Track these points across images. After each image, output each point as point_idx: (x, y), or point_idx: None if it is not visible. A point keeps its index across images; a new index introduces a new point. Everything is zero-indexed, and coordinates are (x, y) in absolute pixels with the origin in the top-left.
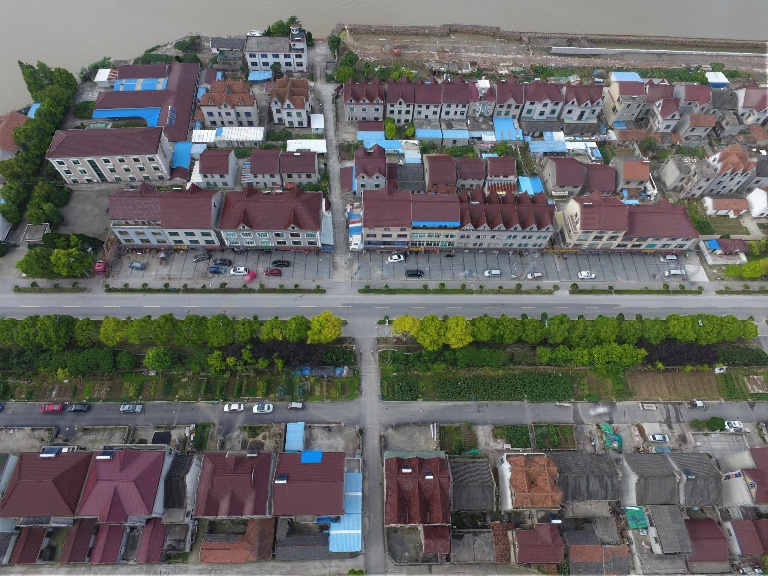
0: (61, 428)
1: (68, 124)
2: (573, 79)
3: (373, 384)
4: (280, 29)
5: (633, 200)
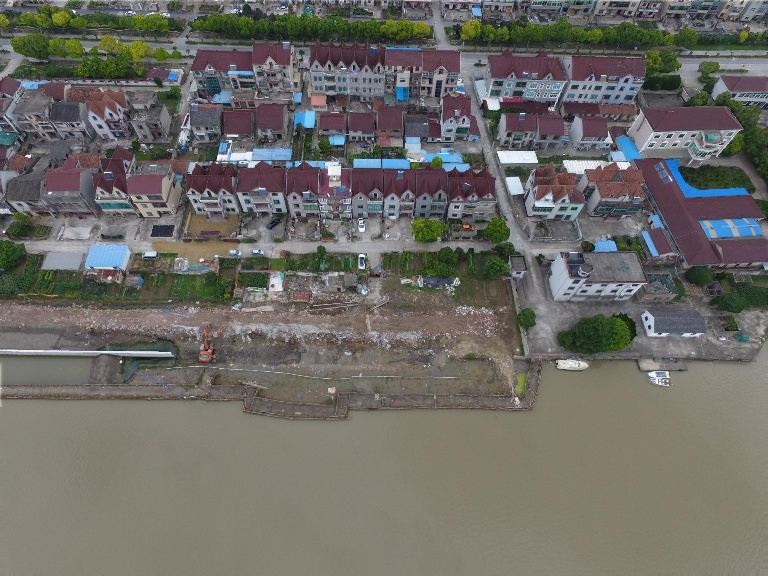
0: (596, 26)
1: (765, 195)
2: (184, 263)
3: (438, 31)
4: (613, 320)
5: (232, 74)
